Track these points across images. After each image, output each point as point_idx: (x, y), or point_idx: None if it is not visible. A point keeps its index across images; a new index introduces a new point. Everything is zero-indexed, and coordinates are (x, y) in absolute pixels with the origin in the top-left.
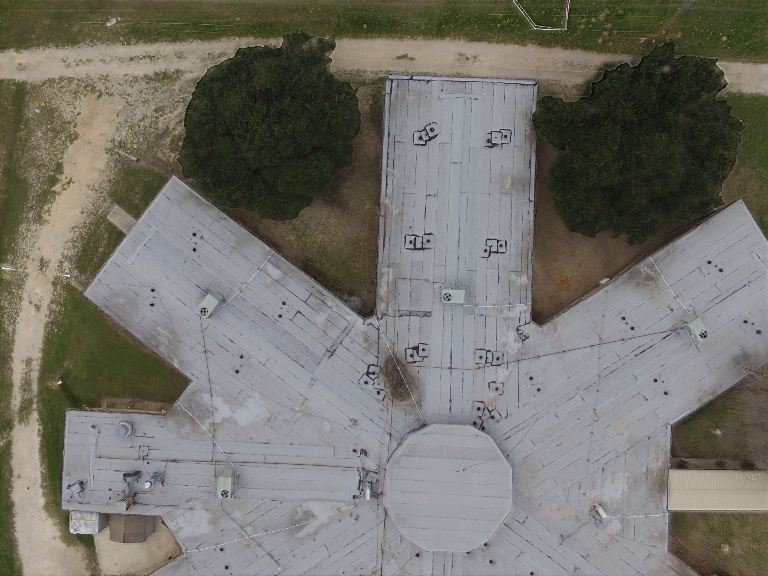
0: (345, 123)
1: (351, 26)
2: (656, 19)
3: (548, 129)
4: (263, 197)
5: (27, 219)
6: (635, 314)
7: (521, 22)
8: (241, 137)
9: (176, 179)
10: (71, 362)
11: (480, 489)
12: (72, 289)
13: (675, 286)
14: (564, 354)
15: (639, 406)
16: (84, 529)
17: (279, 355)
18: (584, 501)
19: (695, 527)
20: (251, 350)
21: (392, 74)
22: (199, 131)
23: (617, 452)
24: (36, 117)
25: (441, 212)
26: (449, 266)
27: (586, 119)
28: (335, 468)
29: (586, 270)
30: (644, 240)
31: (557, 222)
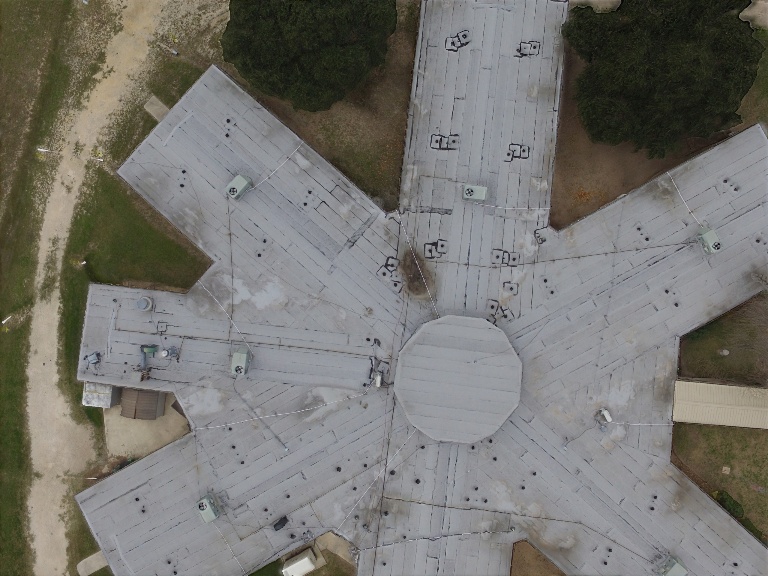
0: (383, 16)
1: None
2: None
3: (577, 36)
4: (299, 83)
5: (66, 104)
6: (650, 226)
7: None
8: (283, 20)
9: (215, 68)
10: (97, 243)
11: (490, 382)
12: (104, 173)
13: (690, 202)
14: (579, 260)
15: (650, 316)
16: (97, 402)
17: (302, 241)
18: (590, 406)
19: (698, 447)
20: (275, 235)
21: None
22: (244, 11)
23: (626, 360)
24: (84, 8)
25: (468, 115)
26: (472, 166)
27: (614, 27)
28: (348, 355)
29: (604, 187)
30: (663, 155)
31: (579, 135)
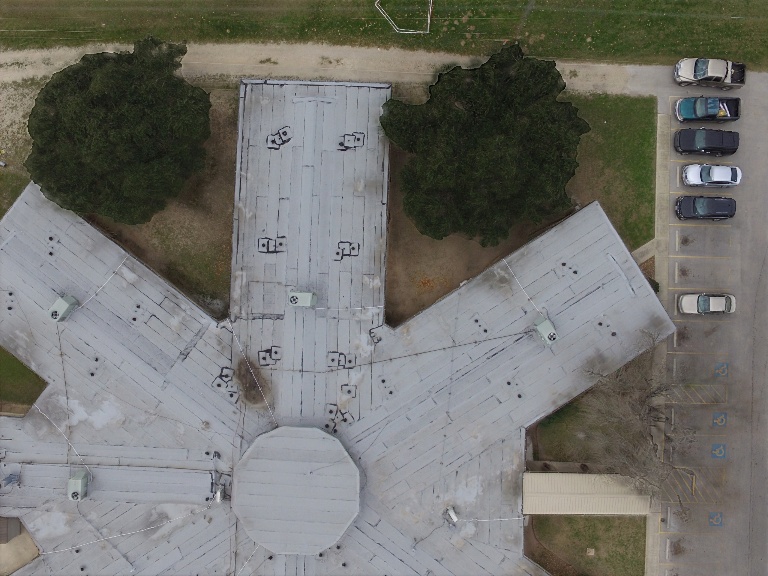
0: (187, 128)
1: (214, 31)
2: (519, 21)
3: (390, 132)
4: (109, 201)
5: None
6: (488, 316)
7: (383, 26)
8: (81, 142)
9: (34, 184)
10: None
11: (327, 492)
12: None
13: (529, 288)
14: (417, 357)
15: (493, 409)
16: None
17: (132, 358)
18: (438, 504)
19: (560, 531)
20: (106, 353)
21: (254, 78)
22: (39, 137)
23: (471, 455)
24: None
25: (293, 215)
26: (301, 269)
27: (425, 122)
28: (188, 471)
29: (448, 272)
30: (497, 242)
31: None
